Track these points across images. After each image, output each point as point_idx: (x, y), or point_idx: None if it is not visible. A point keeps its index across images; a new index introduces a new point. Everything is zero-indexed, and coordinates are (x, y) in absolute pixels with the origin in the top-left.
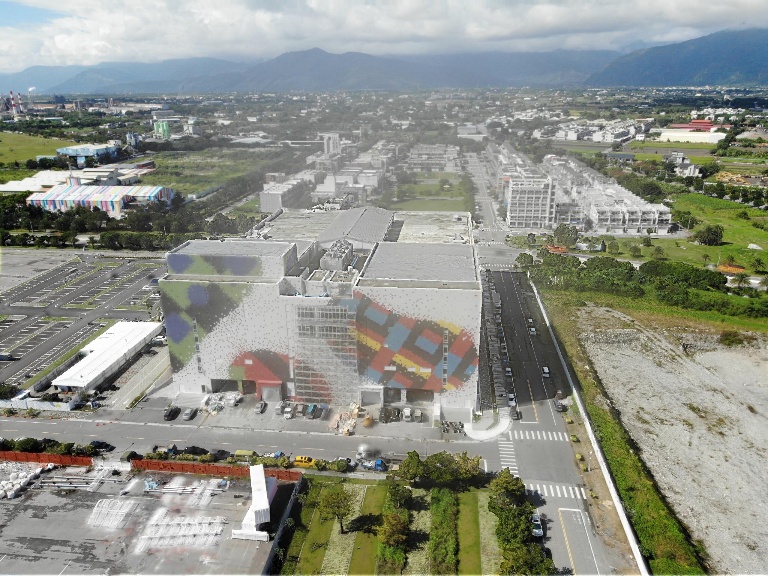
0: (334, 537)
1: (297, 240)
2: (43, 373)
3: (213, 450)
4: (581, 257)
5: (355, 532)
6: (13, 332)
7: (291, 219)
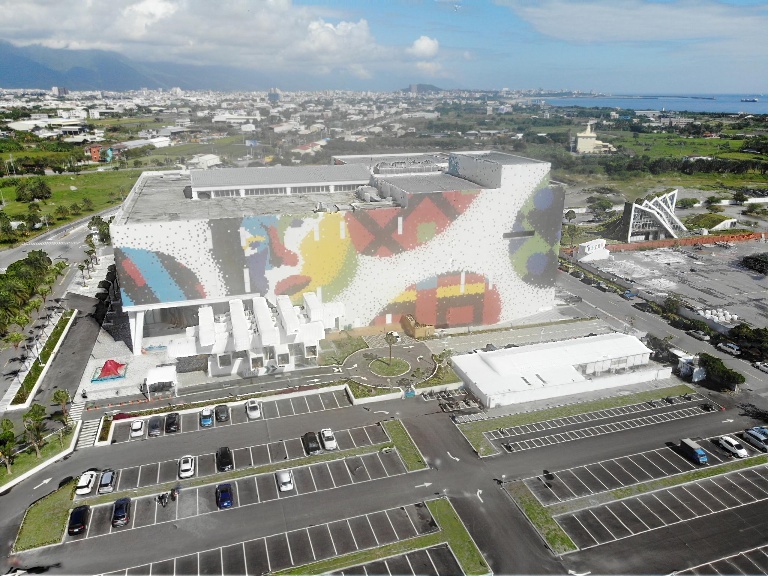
0: (577, 246)
1: (379, 178)
2: (648, 396)
3: (582, 273)
4: (71, 228)
5: (567, 244)
6: (655, 539)
7: (189, 218)
